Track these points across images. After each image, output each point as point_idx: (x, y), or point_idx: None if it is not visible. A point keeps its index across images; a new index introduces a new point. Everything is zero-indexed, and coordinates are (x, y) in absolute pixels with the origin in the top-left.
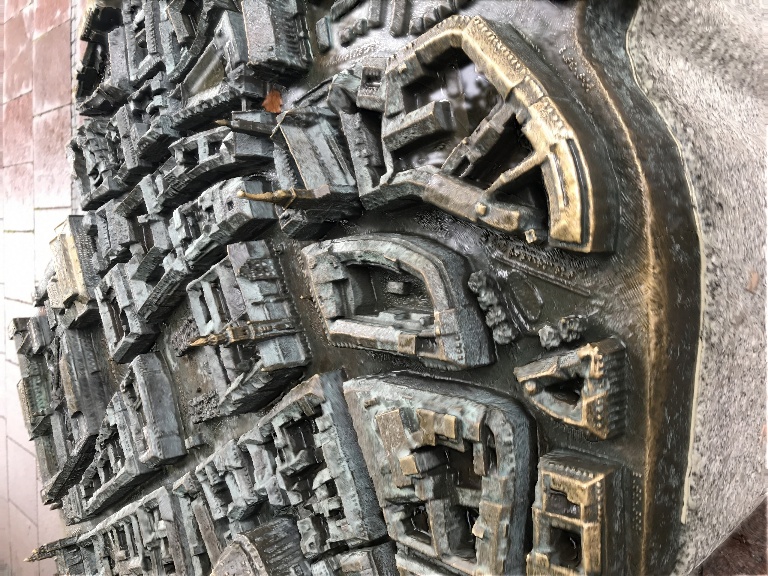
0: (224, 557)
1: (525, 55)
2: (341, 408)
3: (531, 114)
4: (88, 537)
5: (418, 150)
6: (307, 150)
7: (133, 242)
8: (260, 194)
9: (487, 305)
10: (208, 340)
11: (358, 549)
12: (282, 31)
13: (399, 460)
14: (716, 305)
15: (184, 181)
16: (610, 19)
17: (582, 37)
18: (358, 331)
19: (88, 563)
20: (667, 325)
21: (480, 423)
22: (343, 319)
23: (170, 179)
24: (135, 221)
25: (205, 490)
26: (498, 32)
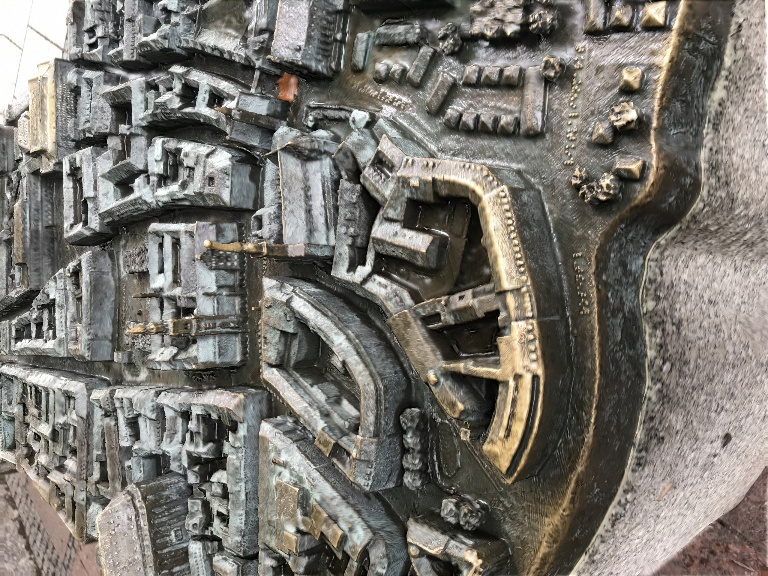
0: (114, 505)
1: (536, 251)
2: (256, 431)
3: (511, 332)
4: (10, 374)
5: (402, 265)
6: (298, 189)
7: (112, 134)
8: (229, 245)
9: (409, 446)
10: (146, 329)
11: (232, 556)
12: (318, 27)
13: (284, 532)
14: (612, 532)
15: (175, 115)
16: (642, 232)
17: (601, 253)
18: (288, 395)
19: (6, 392)
20: (555, 556)
21: (362, 549)
22: (280, 369)
23: (161, 106)
24: (120, 111)
25: (119, 416)
26: (519, 214)
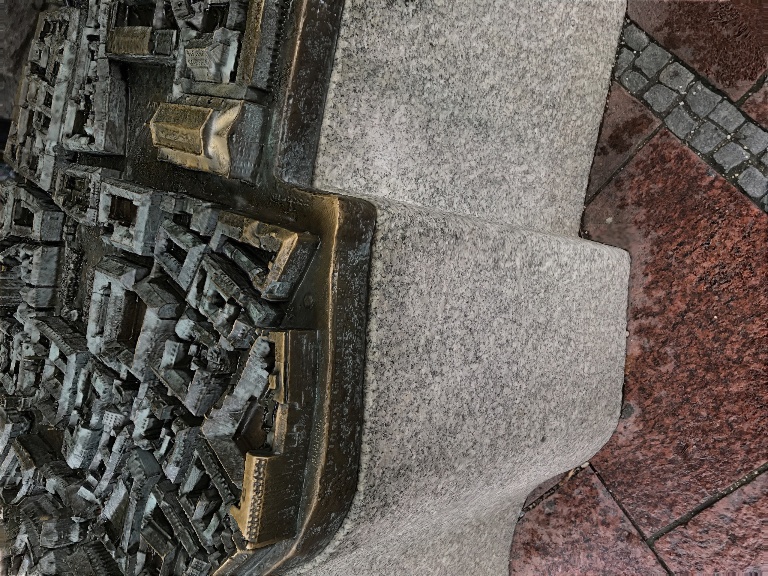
0: None
1: None
2: None
3: None
4: None
5: None
6: None
7: None
8: None
9: None
10: None
11: None
12: None
13: None
14: None
15: None
16: None
17: None
18: (6, 461)
19: None
20: None
21: None
22: None
23: None
24: None
25: None
26: None
